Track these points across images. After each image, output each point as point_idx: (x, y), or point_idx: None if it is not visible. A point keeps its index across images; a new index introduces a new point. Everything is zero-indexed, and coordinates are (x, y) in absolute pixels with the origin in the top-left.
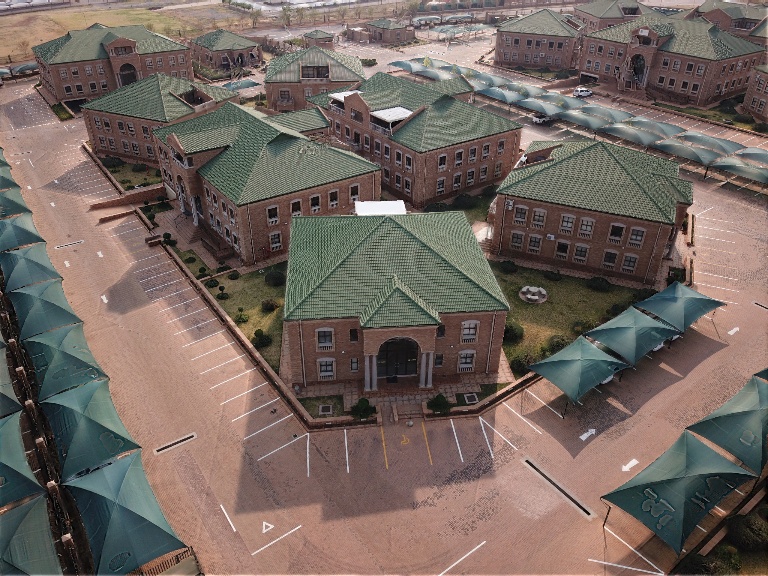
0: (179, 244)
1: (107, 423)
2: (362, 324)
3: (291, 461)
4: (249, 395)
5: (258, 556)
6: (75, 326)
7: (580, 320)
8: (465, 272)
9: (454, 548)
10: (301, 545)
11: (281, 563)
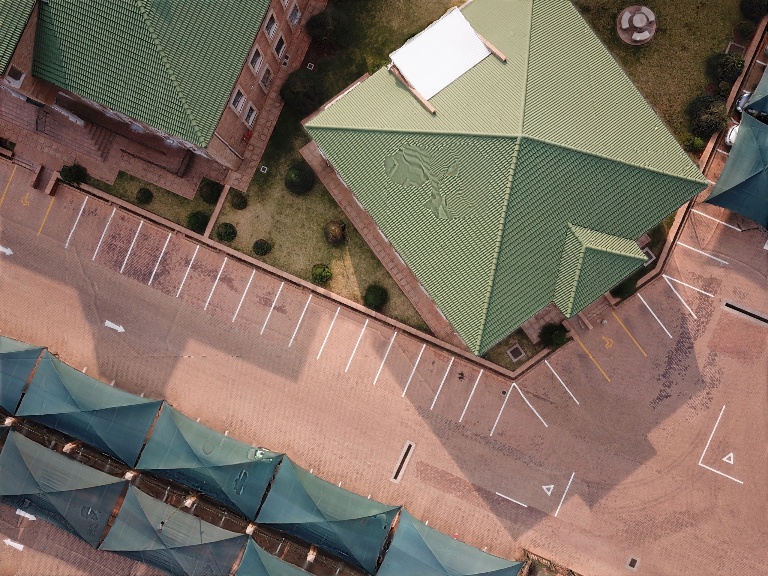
0: (91, 170)
1: (354, 512)
2: (568, 316)
3: (521, 421)
4: (420, 371)
5: (561, 515)
6: (173, 420)
7: (710, 50)
8: (644, 161)
9: (704, 425)
10: (586, 488)
11: (582, 510)
